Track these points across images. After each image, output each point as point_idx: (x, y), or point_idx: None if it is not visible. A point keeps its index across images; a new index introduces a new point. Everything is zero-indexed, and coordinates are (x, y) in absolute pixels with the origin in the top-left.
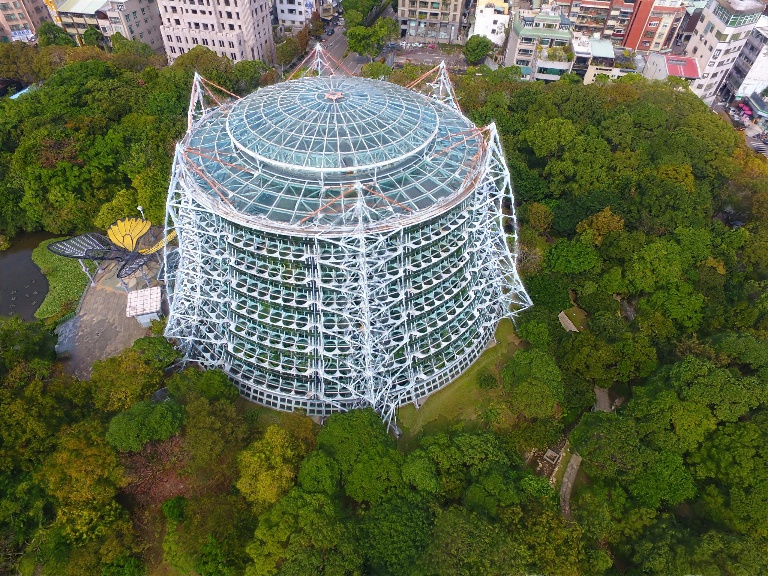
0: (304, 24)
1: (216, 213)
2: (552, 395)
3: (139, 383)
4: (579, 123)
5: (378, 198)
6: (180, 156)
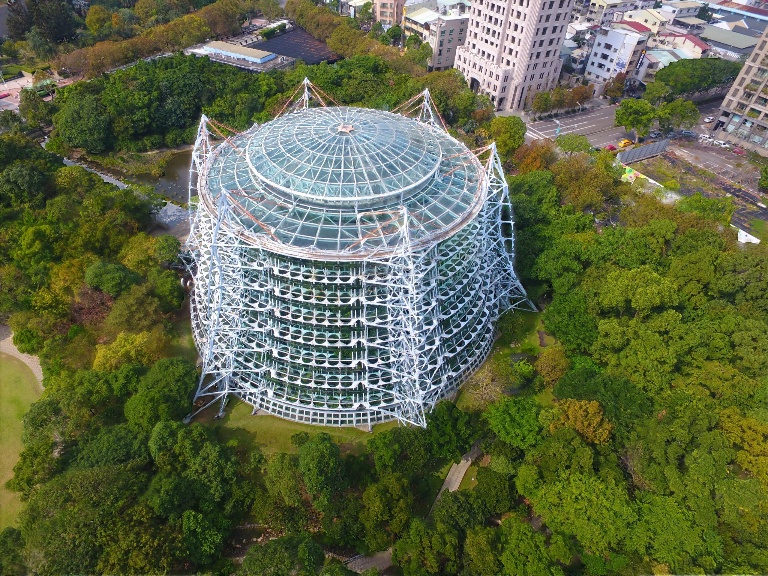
0: (606, 82)
1: (200, 172)
2: (290, 486)
3: (141, 258)
4: (740, 308)
5: (281, 219)
6: (204, 124)
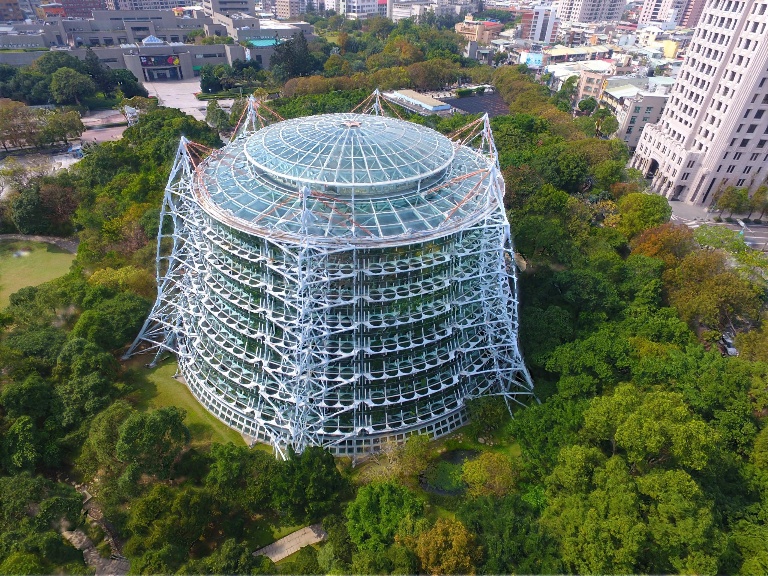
0: None
1: None
2: (100, 439)
3: None
4: None
5: None
6: None
